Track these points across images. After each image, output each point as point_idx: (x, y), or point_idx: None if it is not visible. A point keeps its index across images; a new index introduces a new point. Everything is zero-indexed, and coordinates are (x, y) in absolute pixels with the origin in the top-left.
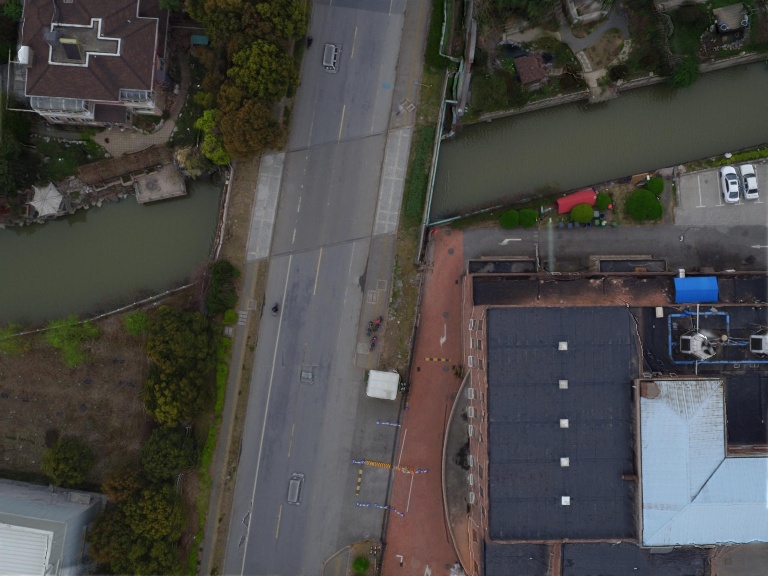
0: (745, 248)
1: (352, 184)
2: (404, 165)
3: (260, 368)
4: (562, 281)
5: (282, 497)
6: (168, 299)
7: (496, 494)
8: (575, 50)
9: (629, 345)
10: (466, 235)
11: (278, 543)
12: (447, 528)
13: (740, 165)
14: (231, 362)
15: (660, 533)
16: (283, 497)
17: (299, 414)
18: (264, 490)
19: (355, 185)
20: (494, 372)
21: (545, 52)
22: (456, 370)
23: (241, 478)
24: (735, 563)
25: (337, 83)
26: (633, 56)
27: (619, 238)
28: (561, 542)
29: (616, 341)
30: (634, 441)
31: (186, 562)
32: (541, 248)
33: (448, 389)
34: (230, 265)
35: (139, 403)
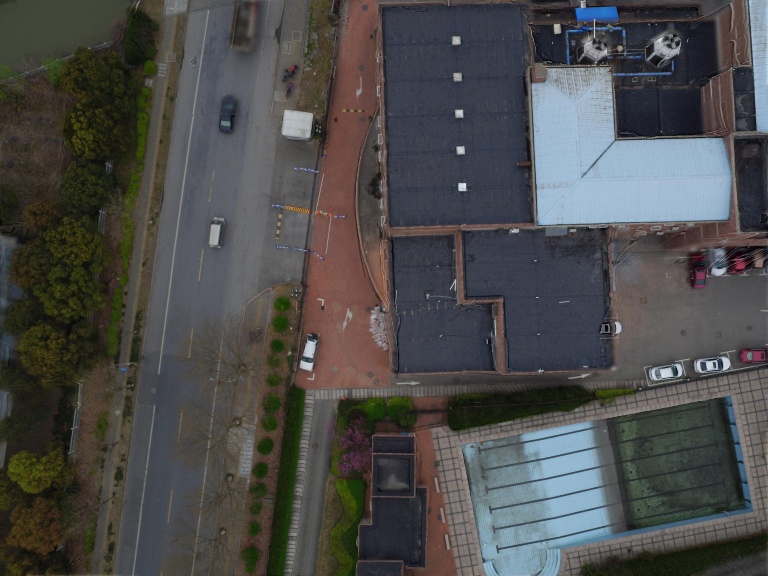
0: None
1: None
2: None
3: (180, 118)
4: None
5: (203, 241)
6: (91, 56)
7: (395, 185)
8: None
9: (522, 41)
10: None
11: (201, 286)
12: (362, 258)
13: None
14: (152, 112)
15: (553, 212)
16: (204, 241)
17: (219, 161)
18: (186, 234)
19: None
20: (391, 69)
21: None
22: (371, 117)
23: (163, 224)
24: (650, 302)
25: None
26: None
27: None
28: (459, 227)
29: (509, 37)
30: (527, 128)
31: (109, 299)
32: (453, 3)
33: (363, 134)
34: (149, 18)
35: (62, 151)
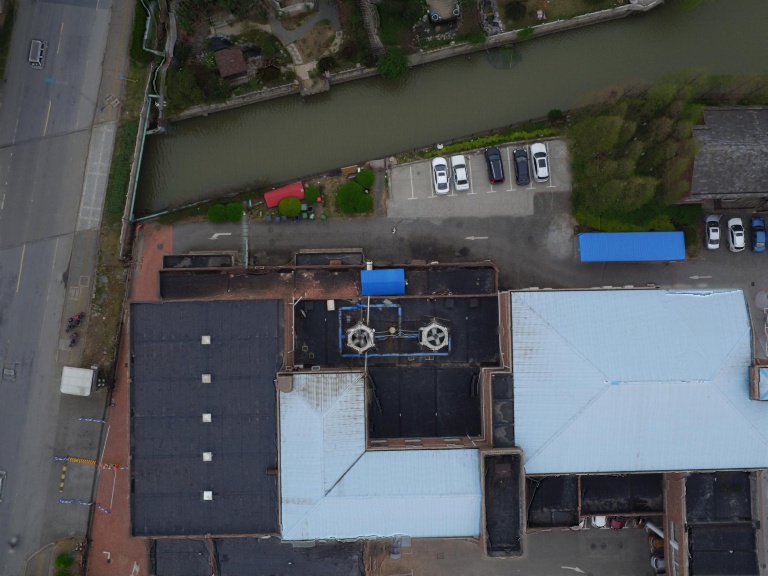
0: (459, 240)
1: (56, 180)
2: (108, 160)
3: None
4: (254, 275)
5: None
6: None
7: (140, 489)
8: (285, 42)
9: (277, 338)
10: (176, 230)
11: None
12: None
13: (452, 156)
14: None
15: (298, 527)
16: None
17: (1, 411)
18: None
19: (59, 181)
20: (139, 367)
21: (254, 45)
22: None
23: None
24: (447, 557)
25: (43, 79)
26: (343, 47)
27: (330, 231)
28: (203, 537)
29: (263, 334)
30: (276, 435)
31: None
32: (251, 242)
33: None
34: None
35: None
